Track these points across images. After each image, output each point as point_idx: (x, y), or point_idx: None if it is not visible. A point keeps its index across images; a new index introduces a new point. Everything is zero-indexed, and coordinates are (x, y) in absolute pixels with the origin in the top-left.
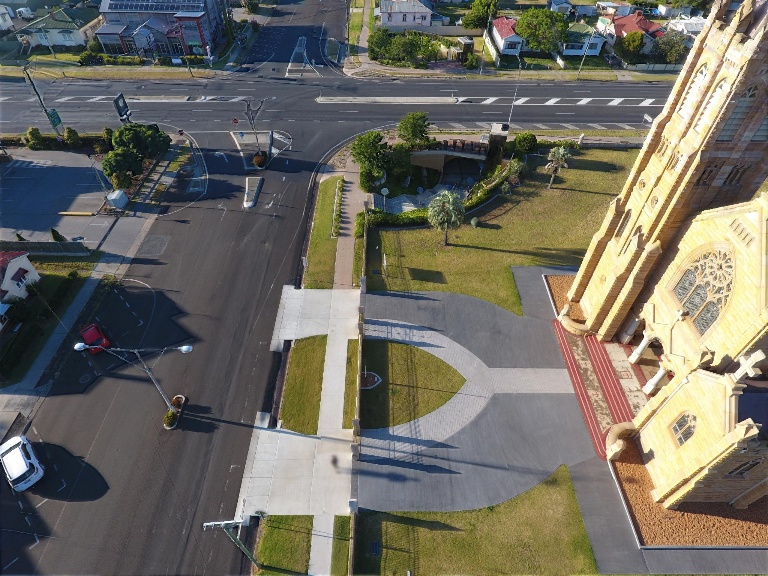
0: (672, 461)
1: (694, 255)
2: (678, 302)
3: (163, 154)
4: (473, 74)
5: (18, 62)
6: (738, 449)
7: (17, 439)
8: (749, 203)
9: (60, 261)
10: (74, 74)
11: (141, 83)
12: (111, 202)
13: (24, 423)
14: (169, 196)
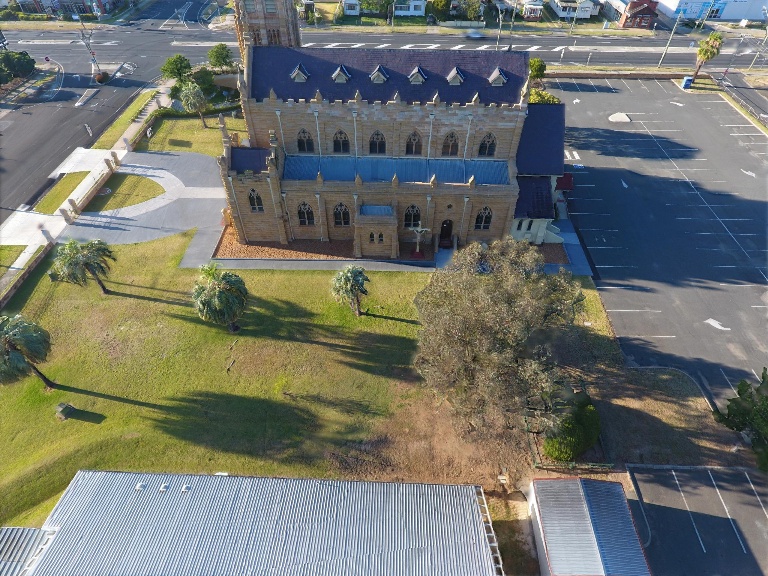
0: None
1: None
2: None
3: (34, 76)
4: (310, 28)
5: None
6: (224, 176)
7: None
8: None
9: None
10: None
11: (42, 32)
12: None
13: None
14: (26, 100)
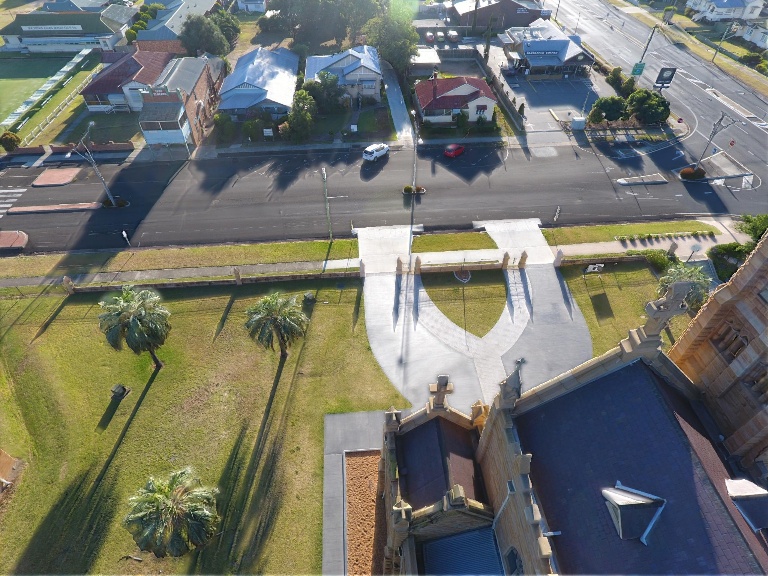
0: None
1: None
2: None
3: (653, 128)
4: None
5: (706, 40)
6: None
7: (387, 146)
8: None
9: (509, 123)
10: (721, 63)
11: (748, 91)
12: (572, 121)
13: (398, 149)
14: (603, 144)
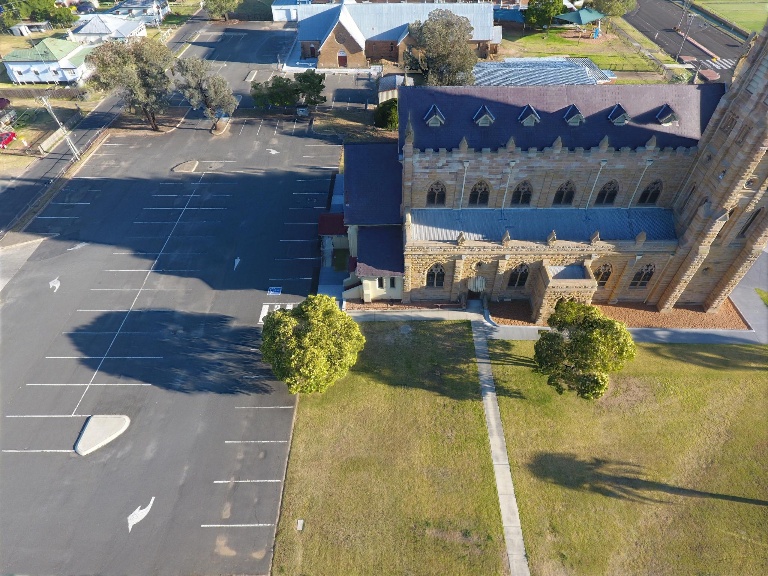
0: None
1: None
2: None
3: None
4: None
5: None
6: None
7: None
8: None
9: None
10: None
11: None
12: None
13: None
14: None
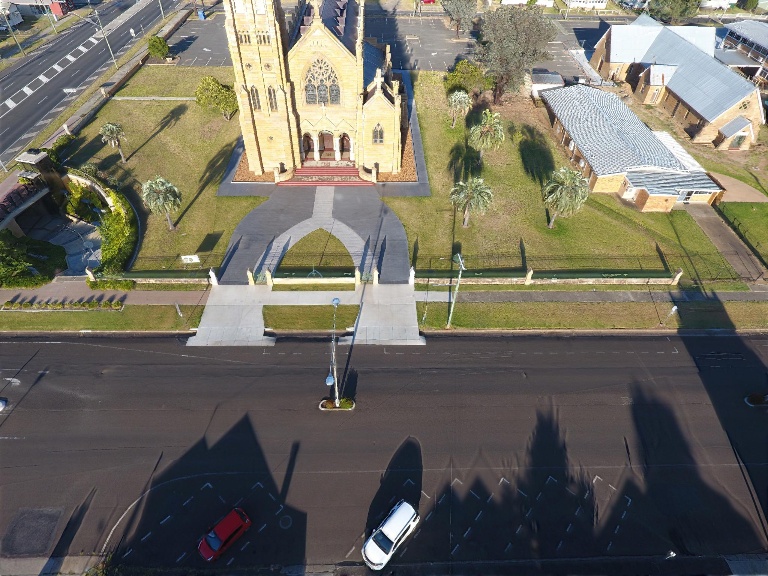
0: (387, 152)
1: (304, 76)
2: (315, 105)
3: None
4: None
5: None
6: None
7: (369, 546)
8: (309, 30)
9: None
10: None
11: None
12: None
13: (341, 571)
14: None
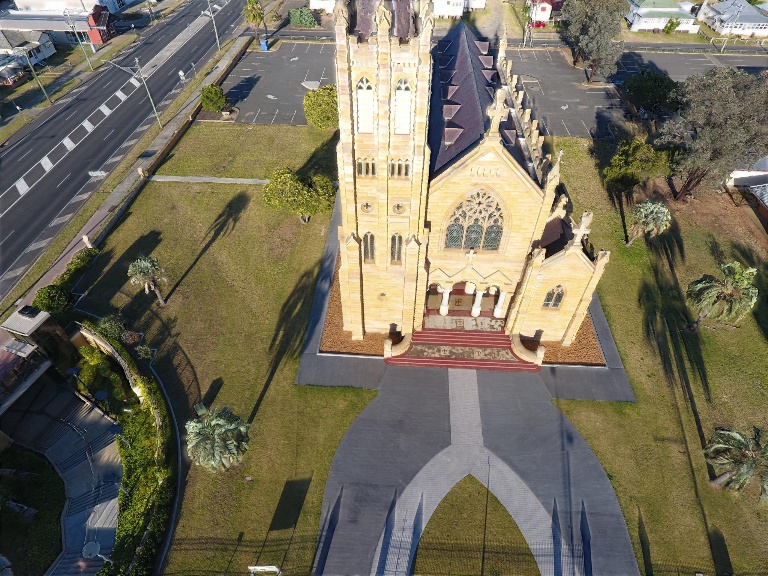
0: (561, 319)
1: (450, 214)
2: (458, 250)
3: None
4: None
5: None
6: None
7: None
8: (475, 152)
9: None
10: None
11: None
12: None
13: None
14: None
